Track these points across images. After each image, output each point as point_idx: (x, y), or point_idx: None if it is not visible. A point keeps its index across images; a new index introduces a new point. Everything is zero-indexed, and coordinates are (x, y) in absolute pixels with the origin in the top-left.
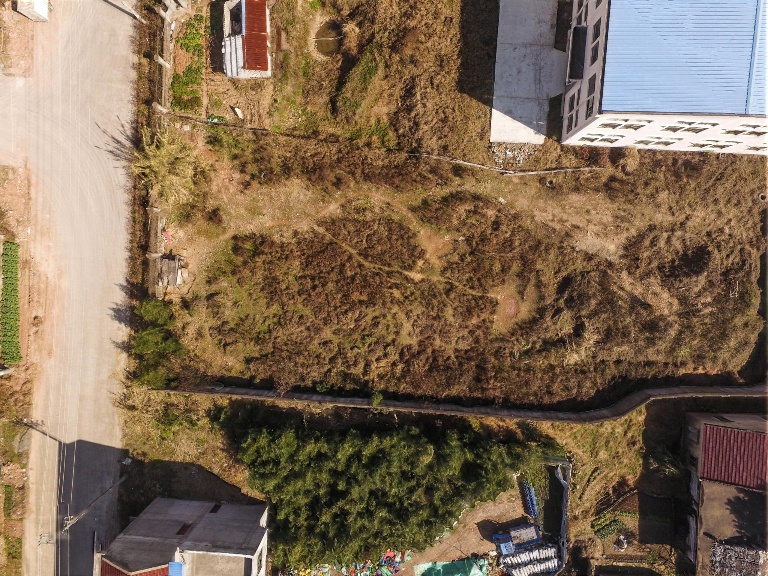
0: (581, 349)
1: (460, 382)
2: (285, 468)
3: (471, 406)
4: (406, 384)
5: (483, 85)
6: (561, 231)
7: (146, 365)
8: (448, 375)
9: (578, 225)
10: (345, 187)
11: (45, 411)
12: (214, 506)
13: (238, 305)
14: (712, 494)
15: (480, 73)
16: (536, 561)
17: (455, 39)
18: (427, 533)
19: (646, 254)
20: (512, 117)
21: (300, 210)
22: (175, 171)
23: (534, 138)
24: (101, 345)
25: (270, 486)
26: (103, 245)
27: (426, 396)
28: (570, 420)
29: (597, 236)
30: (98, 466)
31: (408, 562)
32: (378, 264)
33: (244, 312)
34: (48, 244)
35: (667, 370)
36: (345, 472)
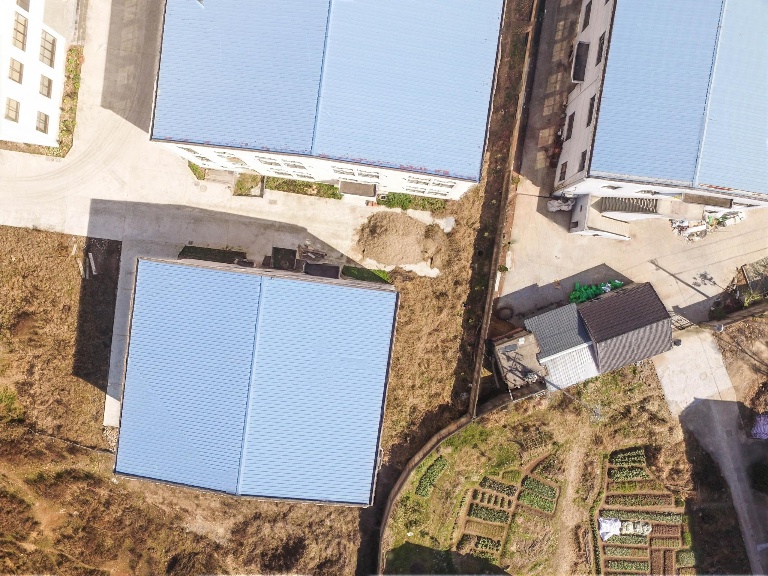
0: None
1: None
2: None
3: None
4: None
5: (98, 371)
6: (171, 514)
7: None
8: None
9: (187, 509)
10: None
11: None
12: None
13: None
14: None
15: (95, 360)
16: None
17: (73, 326)
18: None
19: (252, 540)
20: None
21: None
22: None
23: None
24: None
25: None
26: None
27: None
28: None
29: (206, 520)
30: None
31: None
32: None
33: None
34: None
35: None
36: None
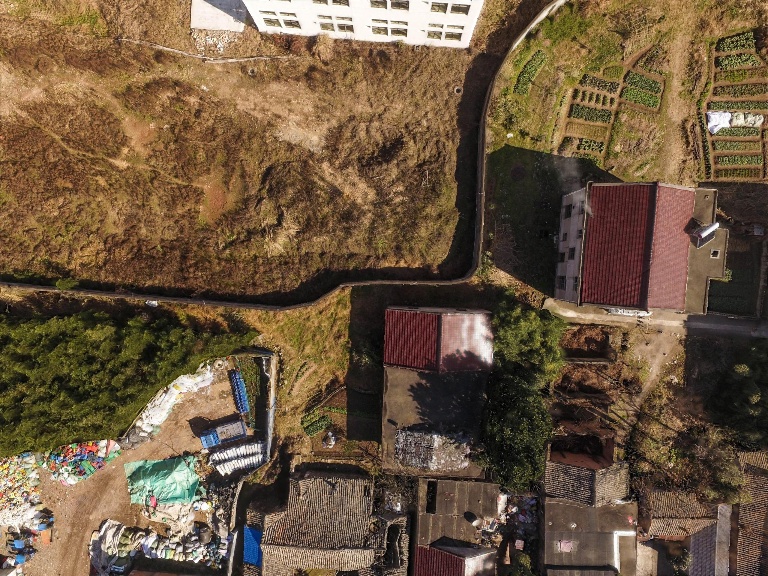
0: (276, 237)
1: (162, 271)
2: None
3: (174, 296)
4: (106, 272)
5: None
6: (263, 120)
7: None
8: (149, 263)
9: (280, 115)
10: (48, 71)
11: None
12: None
13: None
14: (395, 380)
15: None
16: (242, 457)
17: None
18: (106, 417)
19: (347, 145)
20: (212, 4)
21: (2, 93)
22: None
23: (234, 26)
24: None
25: None
26: None
27: (126, 284)
28: (262, 307)
29: (299, 126)
30: None
31: (118, 460)
32: (81, 150)
33: None
34: None
35: (368, 262)
36: (32, 357)
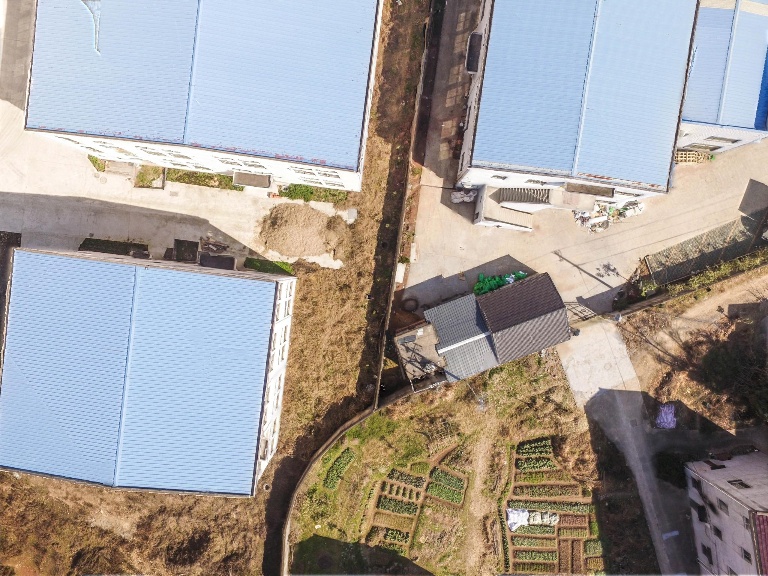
0: None
1: None
2: None
3: None
4: None
5: None
6: (74, 508)
7: None
8: None
9: (91, 503)
10: None
11: None
12: None
13: None
14: None
15: None
16: None
17: None
18: None
19: (158, 534)
20: None
21: None
22: None
23: None
24: None
25: None
26: None
27: None
28: None
29: (111, 514)
30: None
31: None
32: None
33: None
34: None
35: None
36: None
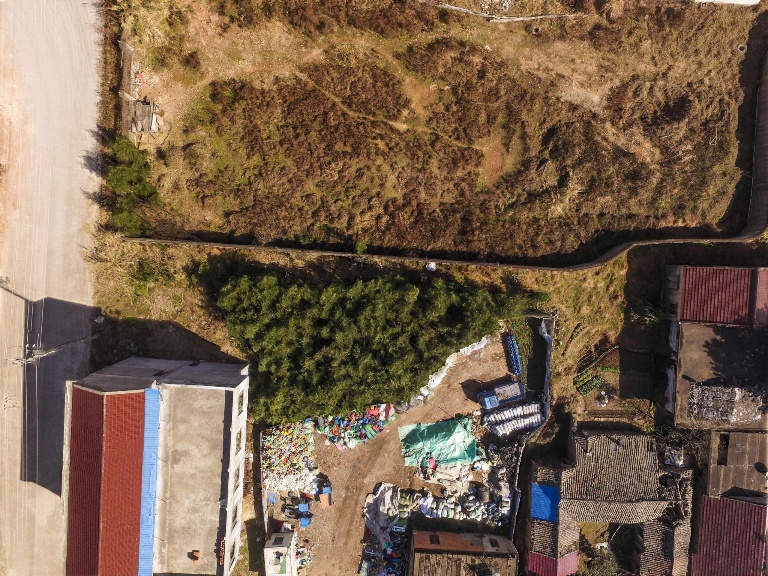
0: (565, 197)
1: (445, 234)
2: (267, 314)
3: (456, 260)
4: (391, 236)
5: None
6: (546, 80)
7: (119, 208)
8: (433, 227)
9: (563, 74)
10: (328, 32)
11: (10, 266)
12: (192, 363)
13: (217, 156)
14: (691, 337)
15: None
16: (520, 417)
17: None
18: (412, 378)
19: (629, 105)
20: None
21: (282, 55)
22: (149, 3)
23: None
24: (70, 196)
25: (251, 334)
26: (72, 88)
27: (411, 248)
28: None
29: (582, 86)
30: (68, 325)
31: (392, 424)
32: (362, 113)
33: (223, 163)
34: (11, 86)
35: (648, 222)
36: (329, 322)
